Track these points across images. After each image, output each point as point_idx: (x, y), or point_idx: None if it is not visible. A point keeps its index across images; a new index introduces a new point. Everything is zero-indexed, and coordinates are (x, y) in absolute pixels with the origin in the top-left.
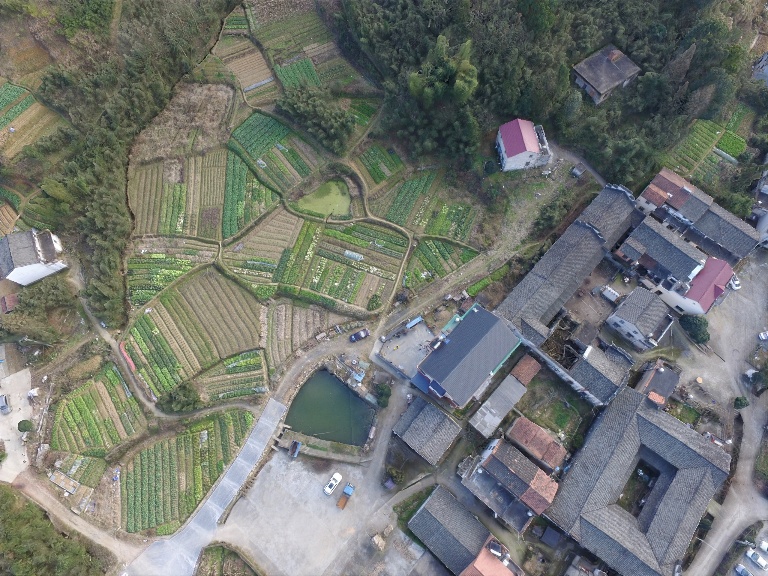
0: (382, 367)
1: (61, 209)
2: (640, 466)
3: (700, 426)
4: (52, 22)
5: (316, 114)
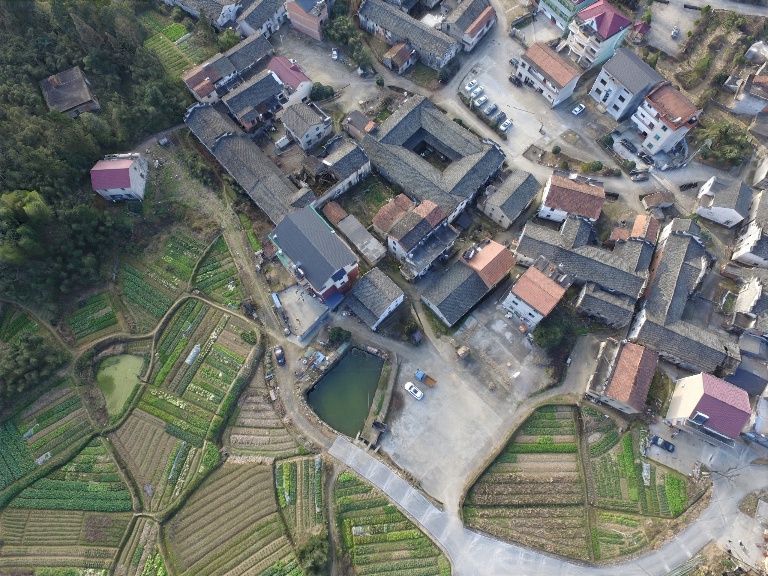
0: (314, 336)
1: None
2: None
3: (394, 111)
4: None
5: (1, 380)
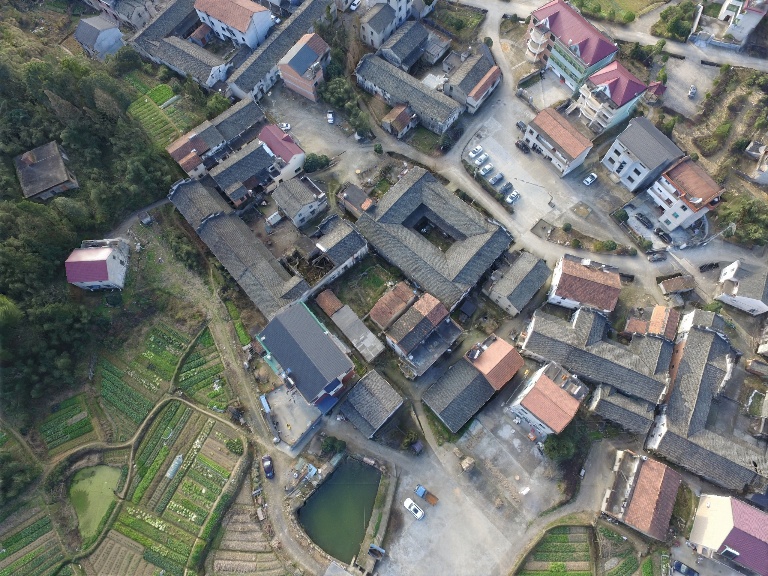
0: (306, 444)
1: None
2: (419, 230)
3: (393, 181)
4: None
5: None
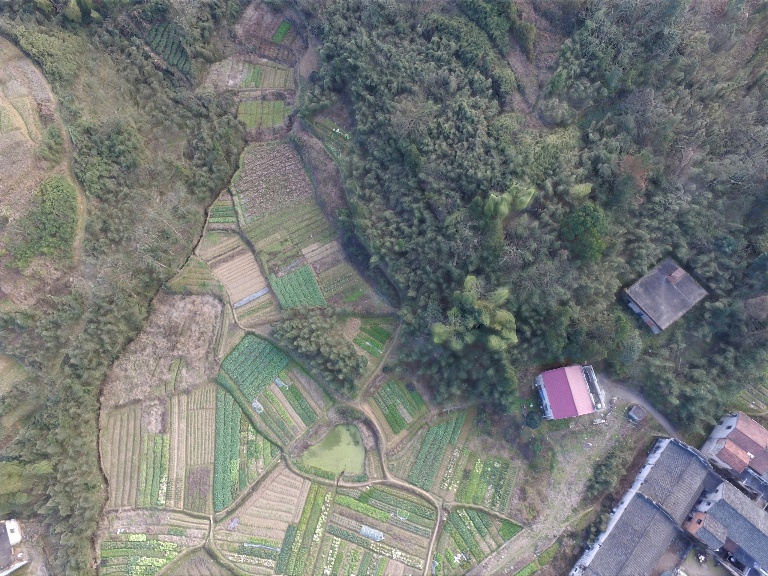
0: None
1: (16, 502)
2: None
3: None
4: (2, 254)
5: None
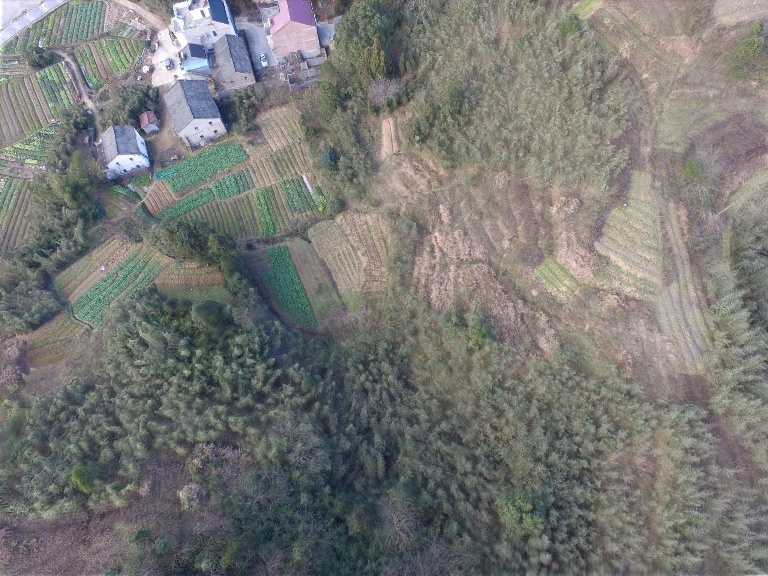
0: None
1: None
2: None
3: None
4: None
5: None
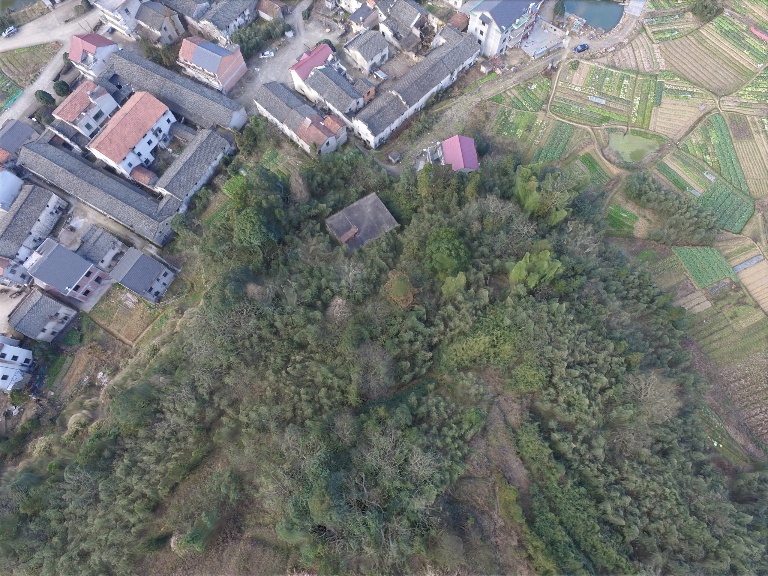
0: None
1: None
2: None
3: None
4: None
5: None
